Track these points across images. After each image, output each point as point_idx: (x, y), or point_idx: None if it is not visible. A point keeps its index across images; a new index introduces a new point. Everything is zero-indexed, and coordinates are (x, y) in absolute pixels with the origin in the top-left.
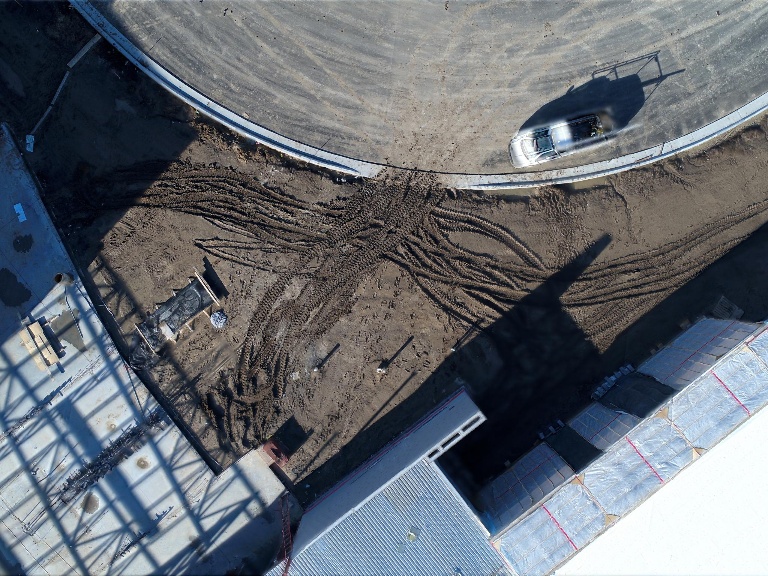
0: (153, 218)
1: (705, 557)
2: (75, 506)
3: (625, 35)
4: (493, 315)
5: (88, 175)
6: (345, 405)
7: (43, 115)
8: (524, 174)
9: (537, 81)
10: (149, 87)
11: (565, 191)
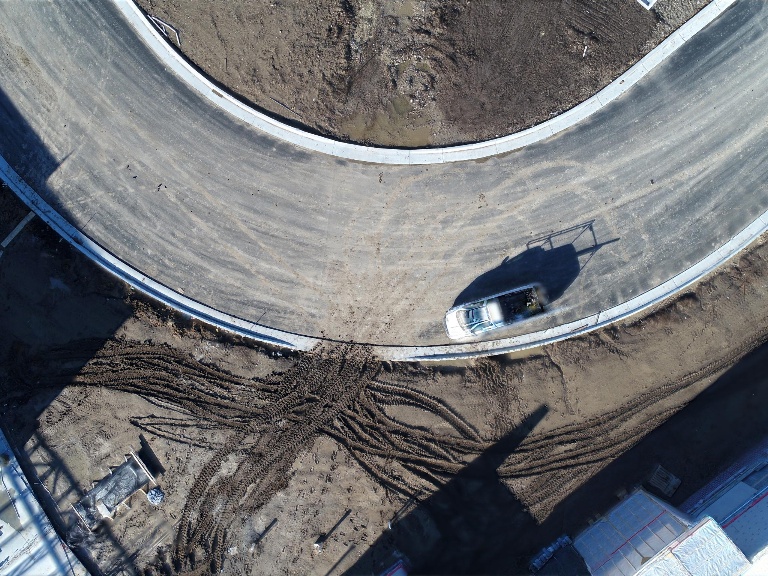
0: (89, 396)
1: None
2: None
3: (559, 205)
4: (430, 488)
5: (23, 354)
6: None
7: None
8: (460, 345)
9: (472, 252)
10: (84, 264)
11: (501, 362)
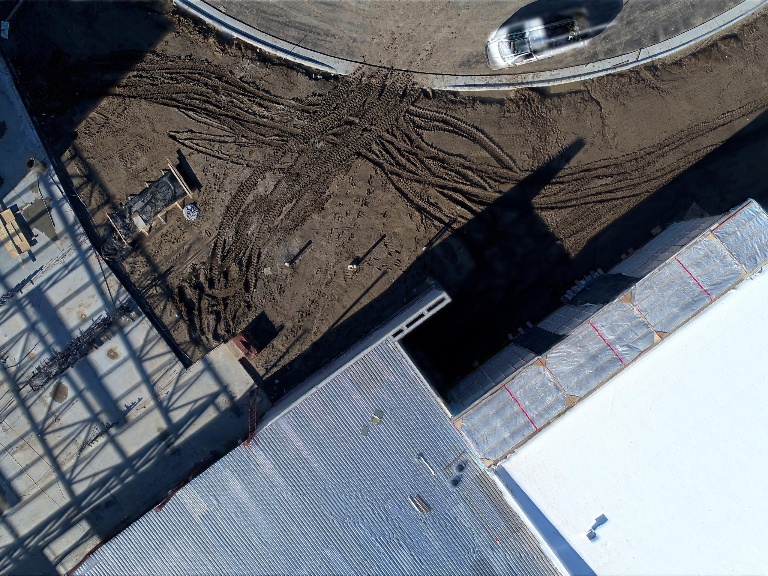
0: (127, 109)
1: (664, 444)
2: (44, 395)
3: None
4: (465, 216)
5: (63, 64)
6: (316, 302)
7: (18, 1)
8: (500, 76)
9: None
10: None
11: (541, 94)
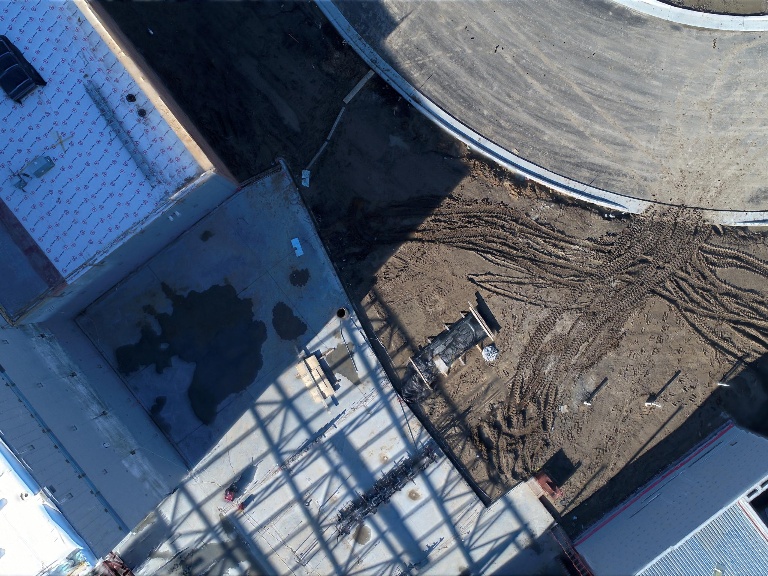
0: (426, 253)
1: None
2: (347, 537)
3: None
4: (759, 350)
5: (362, 210)
6: (613, 438)
7: (319, 150)
8: None
9: None
10: (421, 123)
11: None
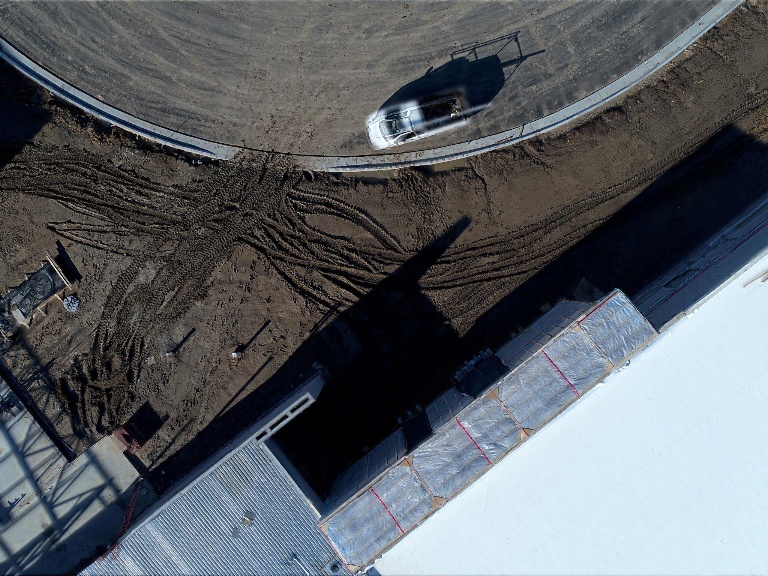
0: (5, 201)
1: (542, 541)
2: None
3: (484, 16)
4: (351, 298)
5: None
6: (201, 390)
7: None
8: (383, 156)
9: (396, 62)
10: (3, 69)
11: (424, 173)
